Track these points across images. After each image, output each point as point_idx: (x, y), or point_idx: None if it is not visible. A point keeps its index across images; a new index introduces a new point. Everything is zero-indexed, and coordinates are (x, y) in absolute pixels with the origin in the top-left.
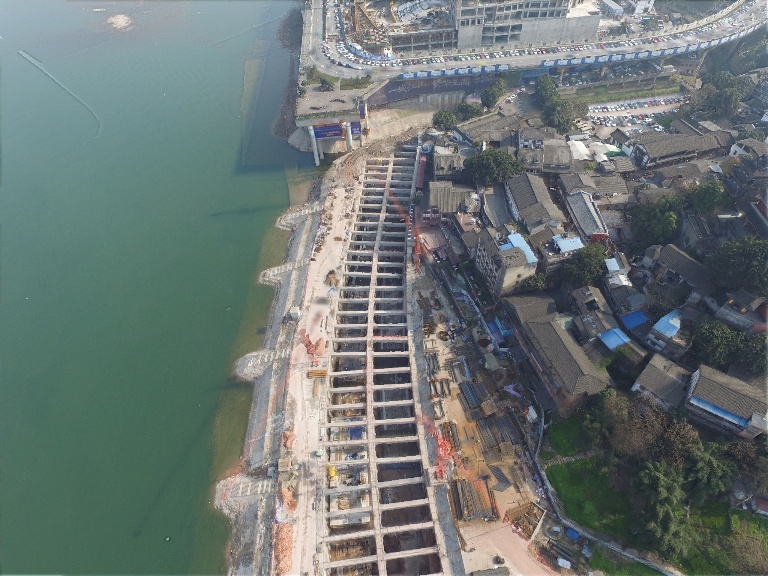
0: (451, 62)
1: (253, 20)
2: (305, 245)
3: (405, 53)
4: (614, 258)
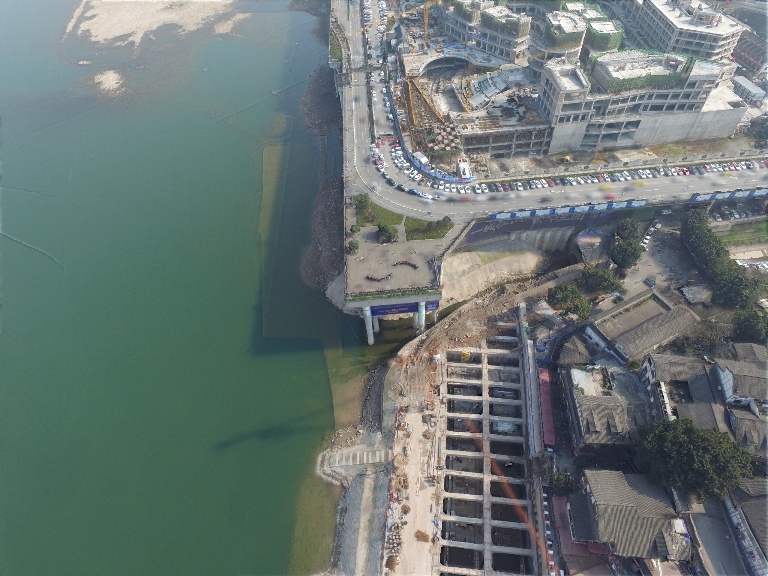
0: (558, 188)
1: (272, 83)
2: (367, 540)
3: (481, 156)
4: None
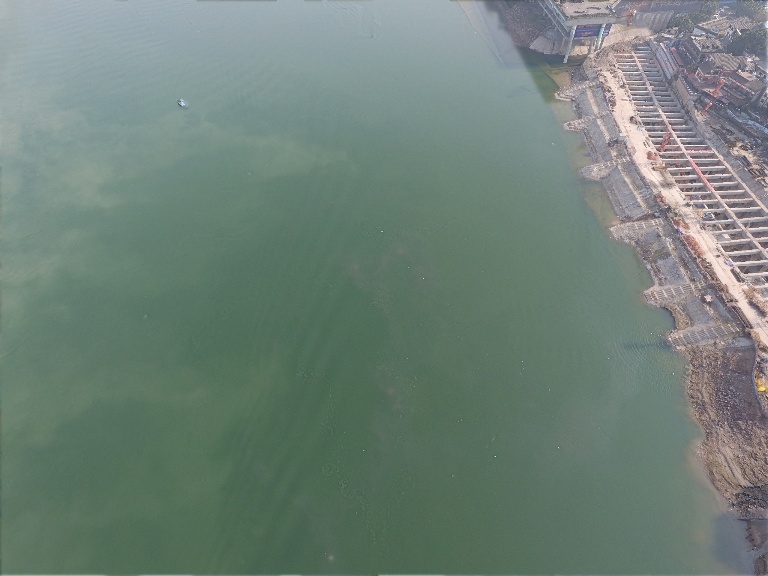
0: None
1: None
2: (596, 105)
3: None
4: None
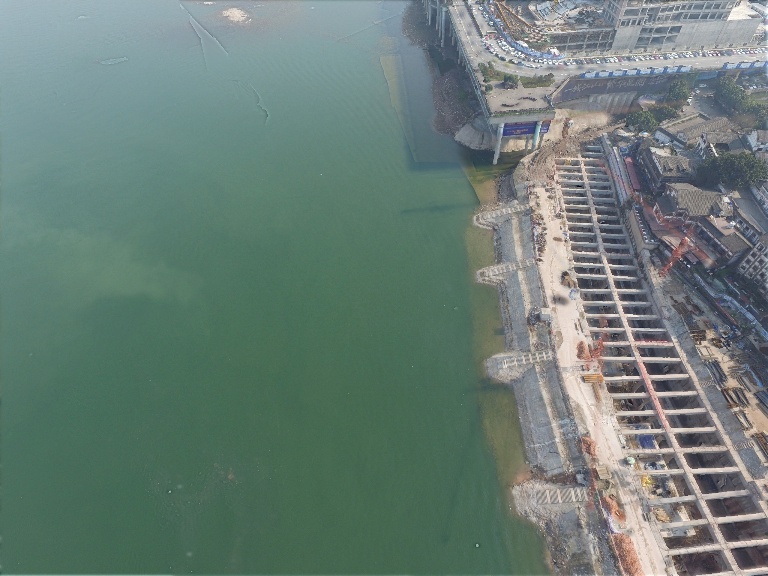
0: (625, 62)
1: (372, 16)
2: (521, 245)
3: (560, 52)
4: None
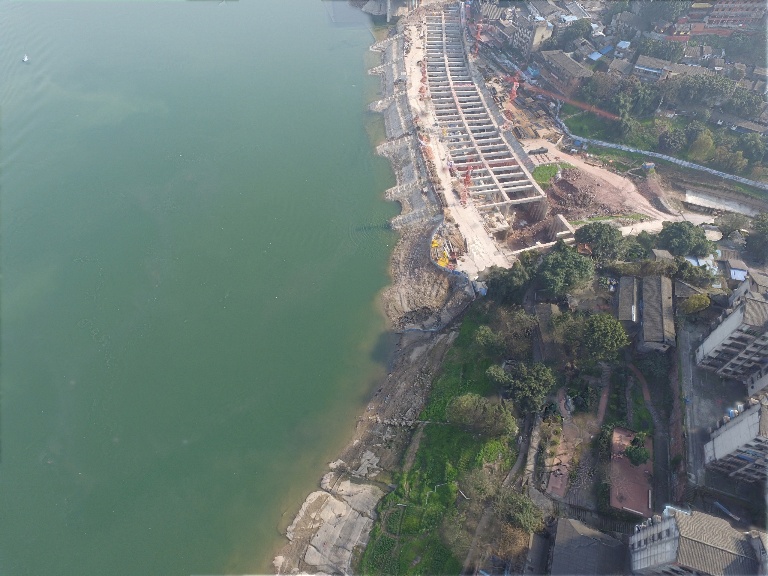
0: None
1: None
2: (396, 53)
3: None
4: (595, 23)
